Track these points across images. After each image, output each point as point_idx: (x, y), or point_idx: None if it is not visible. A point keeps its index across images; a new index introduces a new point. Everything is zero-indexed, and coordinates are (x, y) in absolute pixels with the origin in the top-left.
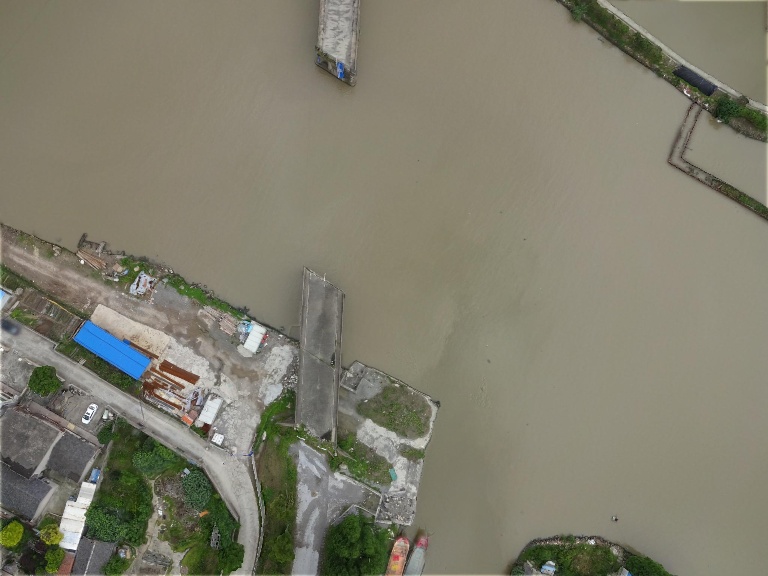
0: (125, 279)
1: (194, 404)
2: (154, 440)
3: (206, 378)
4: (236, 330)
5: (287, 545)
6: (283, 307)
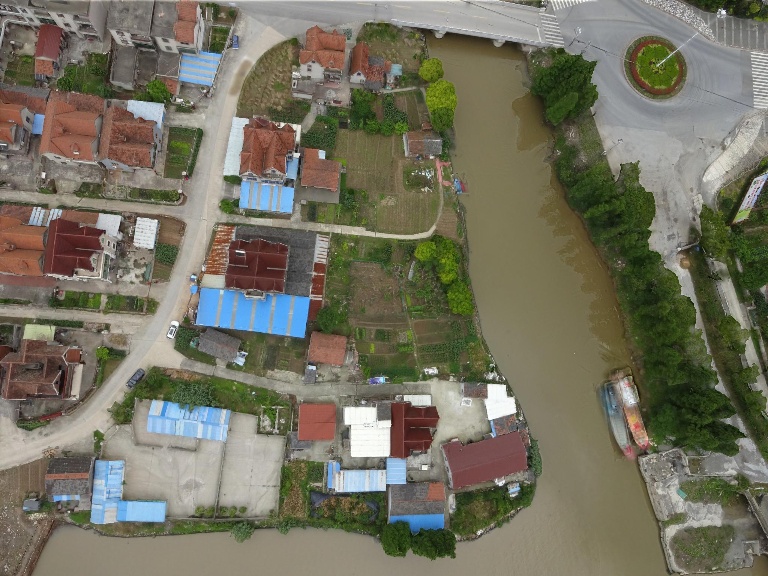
0: None
1: None
2: None
3: None
4: None
5: (760, 407)
6: None
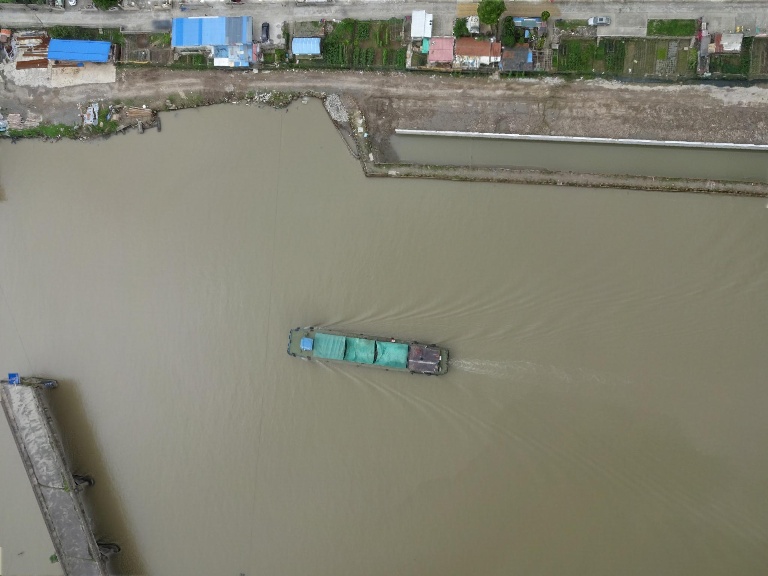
0: (105, 111)
1: (7, 47)
2: (13, 3)
3: (12, 72)
4: (8, 120)
5: None
6: (3, 164)
